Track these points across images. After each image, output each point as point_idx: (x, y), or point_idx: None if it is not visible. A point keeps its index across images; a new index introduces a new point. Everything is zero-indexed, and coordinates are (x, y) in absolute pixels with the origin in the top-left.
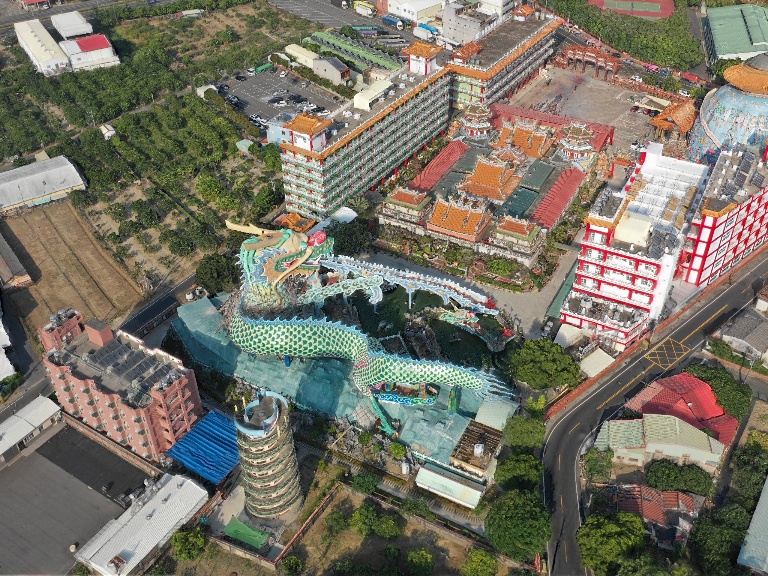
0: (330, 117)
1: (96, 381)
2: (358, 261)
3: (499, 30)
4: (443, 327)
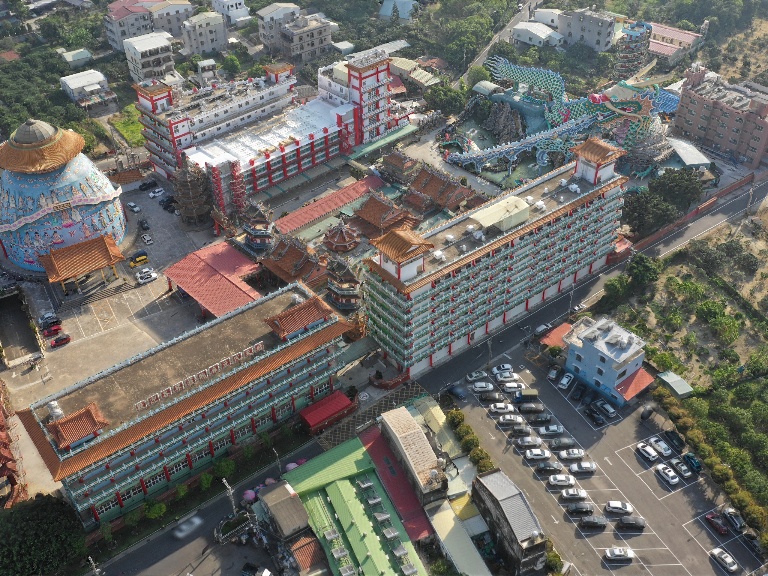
0: (564, 207)
1: (749, 96)
2: (558, 132)
3: (173, 394)
4: (490, 160)
